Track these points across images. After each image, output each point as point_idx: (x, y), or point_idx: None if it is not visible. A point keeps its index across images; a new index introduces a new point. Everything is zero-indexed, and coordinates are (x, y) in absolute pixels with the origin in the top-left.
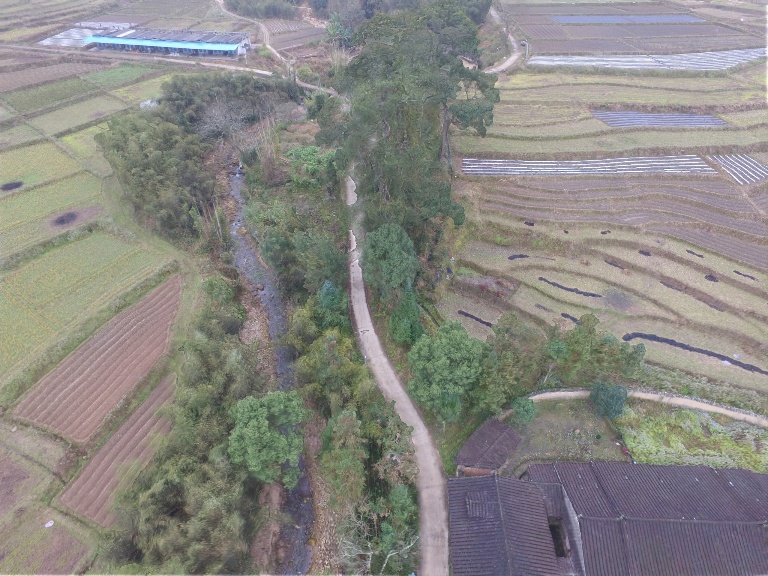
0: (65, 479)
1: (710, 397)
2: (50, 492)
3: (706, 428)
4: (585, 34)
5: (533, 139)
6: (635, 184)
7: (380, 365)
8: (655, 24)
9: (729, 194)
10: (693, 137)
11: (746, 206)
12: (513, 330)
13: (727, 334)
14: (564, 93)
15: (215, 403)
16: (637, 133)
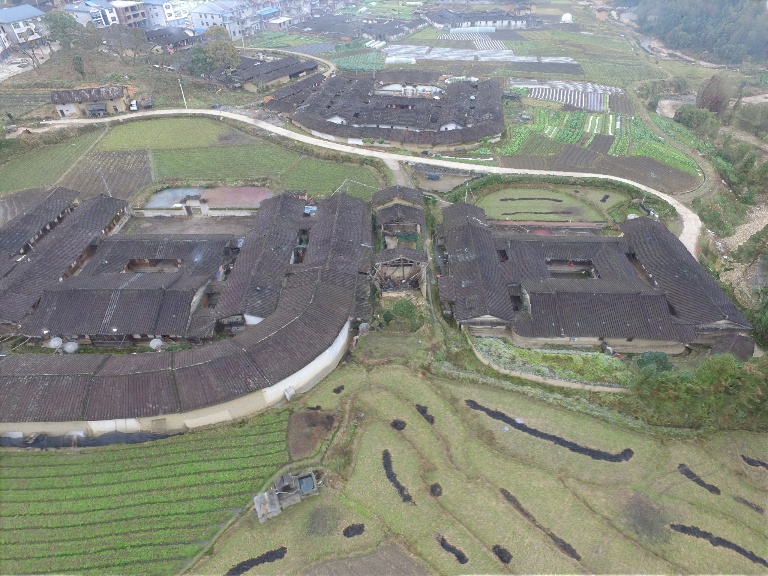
0: None
1: None
2: None
3: None
4: None
5: None
6: None
7: None
8: None
9: None
10: None
11: None
12: None
13: None
14: None
15: None
16: None
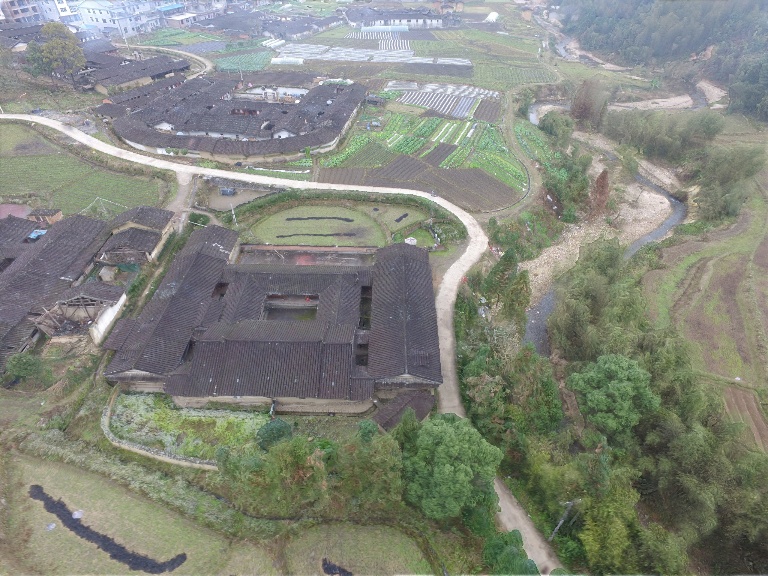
0: (767, 406)
1: (144, 470)
2: (766, 396)
3: (178, 442)
4: None
5: None
6: None
7: (532, 547)
8: None
9: None
10: None
11: None
12: None
13: (20, 568)
14: None
15: (684, 415)
16: None
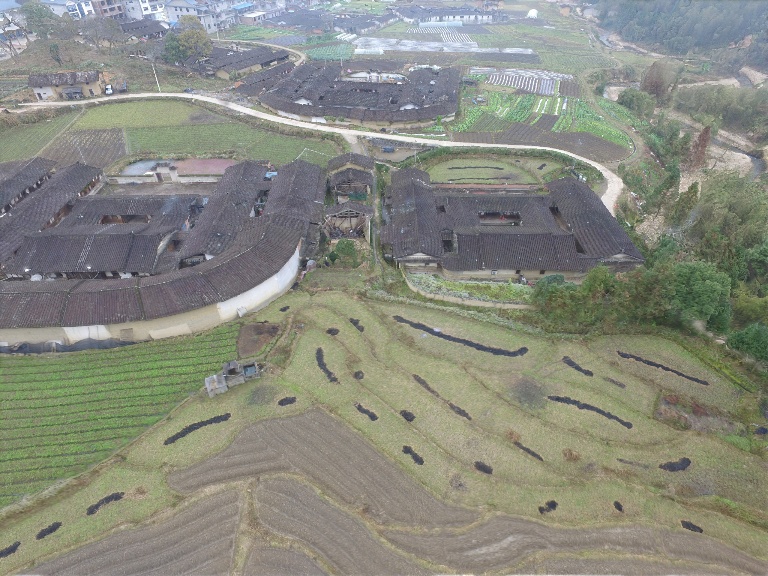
0: None
1: None
2: None
3: None
4: None
5: None
6: None
7: None
8: None
9: None
10: None
11: (260, 569)
12: None
13: None
14: None
15: None
16: None
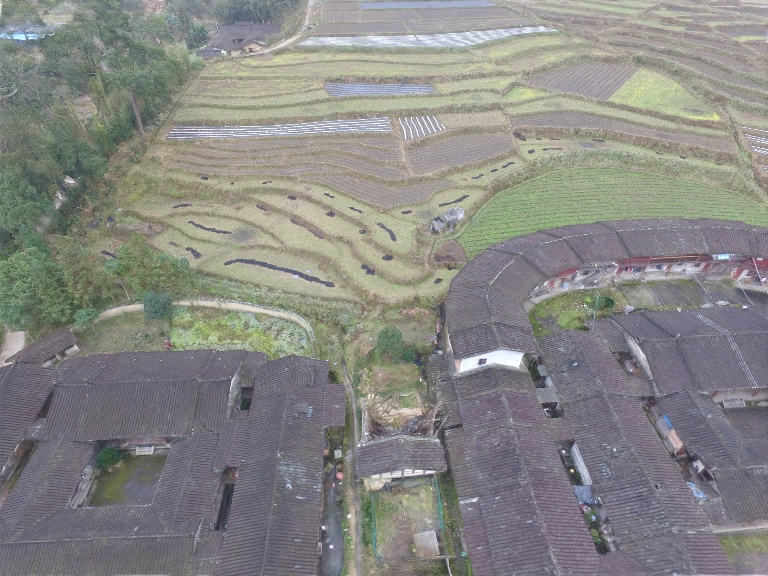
0: None
1: (265, 302)
2: None
3: (247, 325)
4: (376, 18)
5: (250, 108)
6: (314, 142)
7: None
8: (450, 8)
9: (388, 147)
10: (396, 103)
11: (395, 156)
12: (65, 251)
13: (313, 255)
14: (311, 69)
15: None
16: (350, 101)
